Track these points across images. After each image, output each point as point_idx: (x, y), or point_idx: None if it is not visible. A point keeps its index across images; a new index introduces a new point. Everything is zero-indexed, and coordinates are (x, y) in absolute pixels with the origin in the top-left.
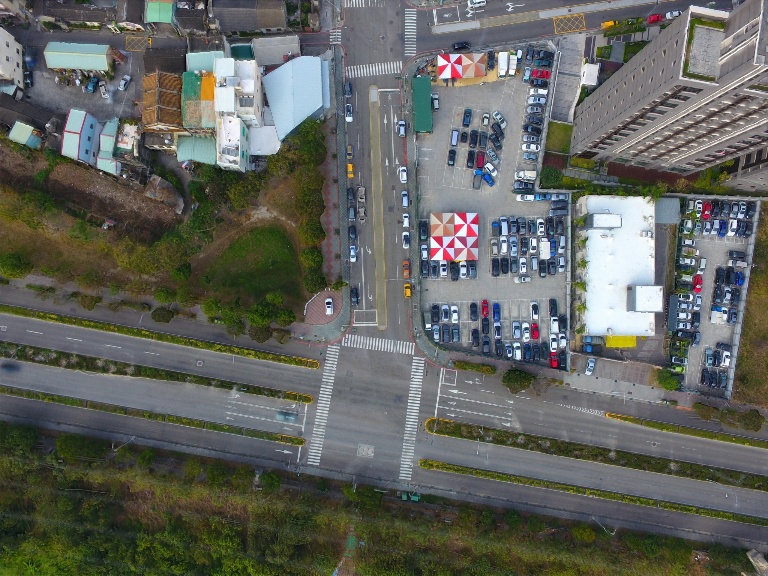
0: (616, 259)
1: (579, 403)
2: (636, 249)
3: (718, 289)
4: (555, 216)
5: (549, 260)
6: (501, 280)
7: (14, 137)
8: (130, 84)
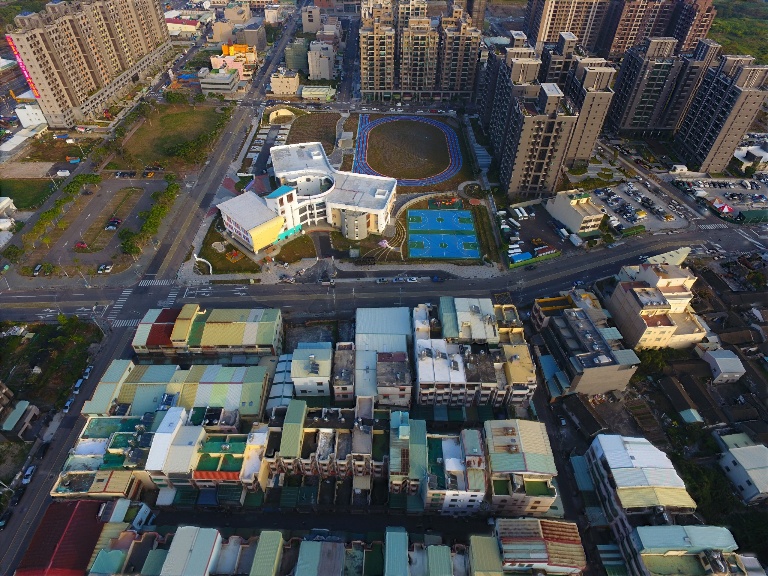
0: None
1: None
2: None
3: None
4: None
5: None
6: None
7: None
8: None
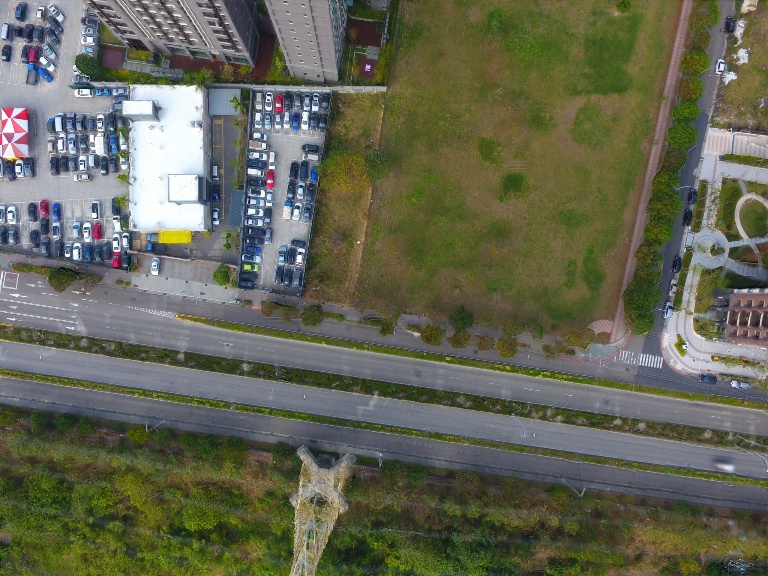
0: (166, 151)
1: (148, 305)
2: (187, 141)
3: (291, 184)
4: (117, 112)
5: (110, 157)
6: (63, 179)
7: None
8: None
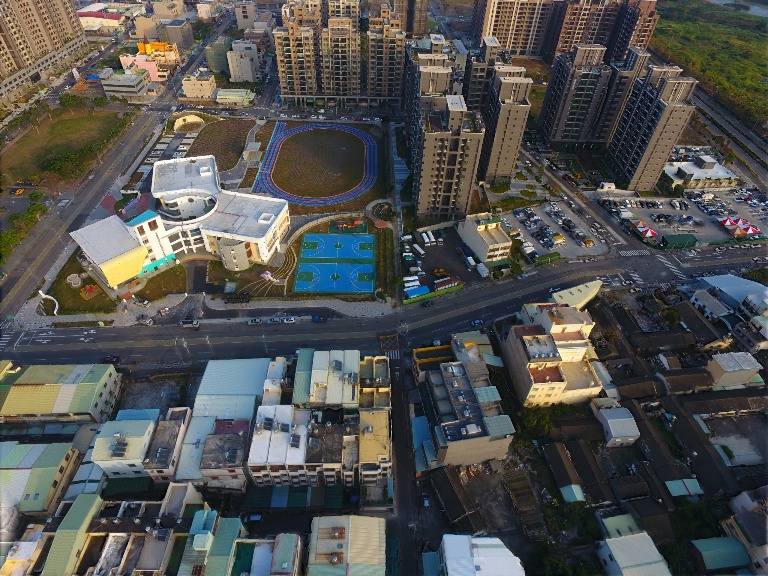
0: None
1: (764, 186)
2: None
3: None
4: None
5: None
6: None
7: None
8: None
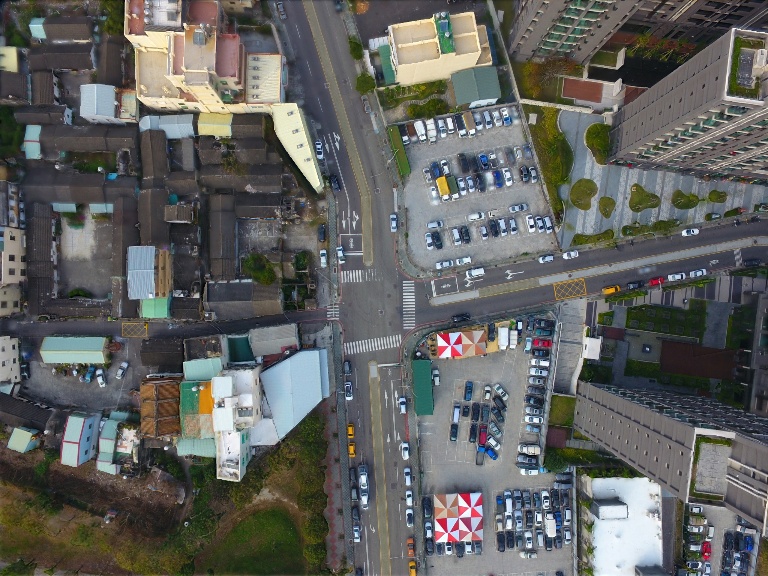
0: (623, 539)
1: None
2: (643, 528)
3: (727, 556)
4: None
5: None
6: (507, 554)
7: (13, 446)
8: (127, 370)
